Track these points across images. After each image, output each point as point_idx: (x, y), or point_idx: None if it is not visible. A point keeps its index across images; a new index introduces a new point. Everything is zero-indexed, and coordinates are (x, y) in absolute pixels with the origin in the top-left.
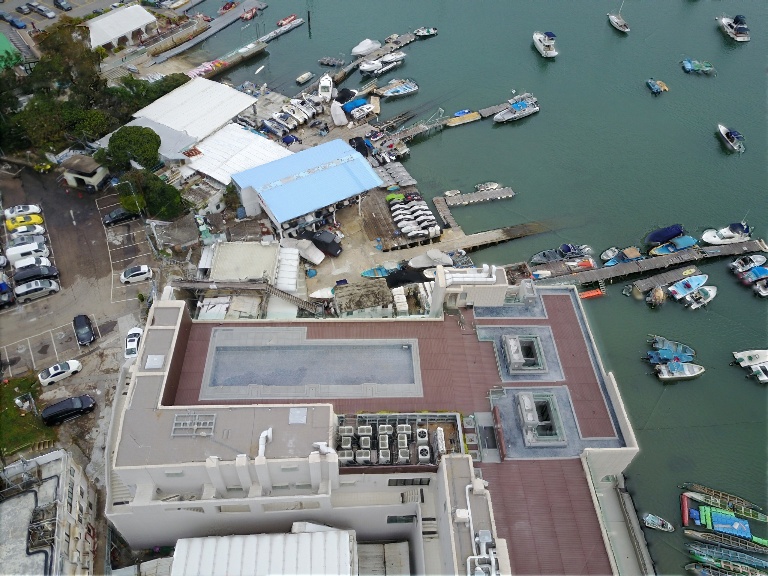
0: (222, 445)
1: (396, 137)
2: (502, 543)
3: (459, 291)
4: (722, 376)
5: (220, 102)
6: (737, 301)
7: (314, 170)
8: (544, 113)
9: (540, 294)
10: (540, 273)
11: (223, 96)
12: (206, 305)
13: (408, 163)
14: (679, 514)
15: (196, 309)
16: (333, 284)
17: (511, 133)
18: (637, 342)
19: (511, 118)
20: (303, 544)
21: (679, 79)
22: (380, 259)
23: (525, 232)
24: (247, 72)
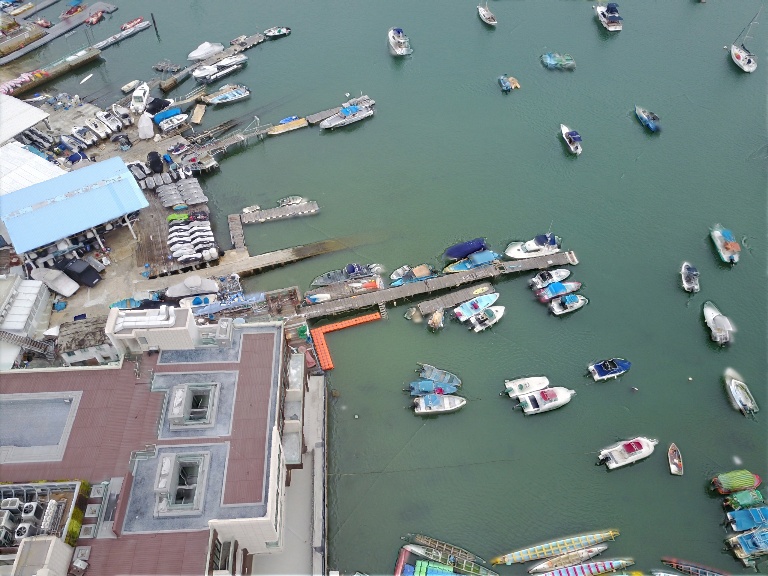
0: None
1: (204, 149)
2: None
3: (129, 337)
4: (488, 408)
5: (6, 119)
6: (528, 321)
7: (73, 193)
8: (379, 117)
9: (242, 333)
10: (317, 297)
11: (12, 112)
12: None
13: (218, 177)
14: (393, 570)
15: None
16: None
17: (340, 140)
18: (405, 372)
19: (338, 124)
20: None
21: (536, 74)
22: (142, 287)
23: (317, 251)
24: (75, 81)
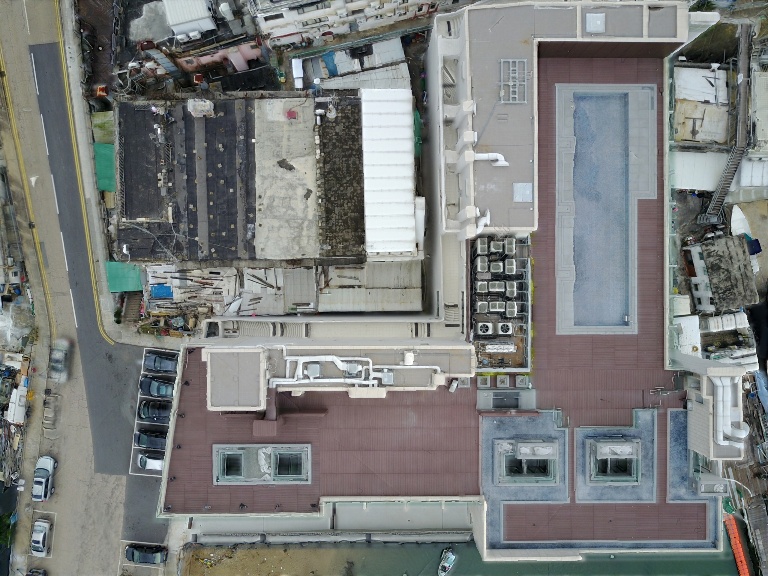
0: (490, 115)
1: None
2: (381, 394)
3: (702, 393)
4: None
5: None
6: None
7: None
8: None
9: (708, 501)
10: None
11: None
12: (715, 75)
13: None
14: None
15: (707, 63)
16: (759, 236)
17: None
18: None
19: None
20: (404, 208)
21: None
22: None
23: None
24: None
